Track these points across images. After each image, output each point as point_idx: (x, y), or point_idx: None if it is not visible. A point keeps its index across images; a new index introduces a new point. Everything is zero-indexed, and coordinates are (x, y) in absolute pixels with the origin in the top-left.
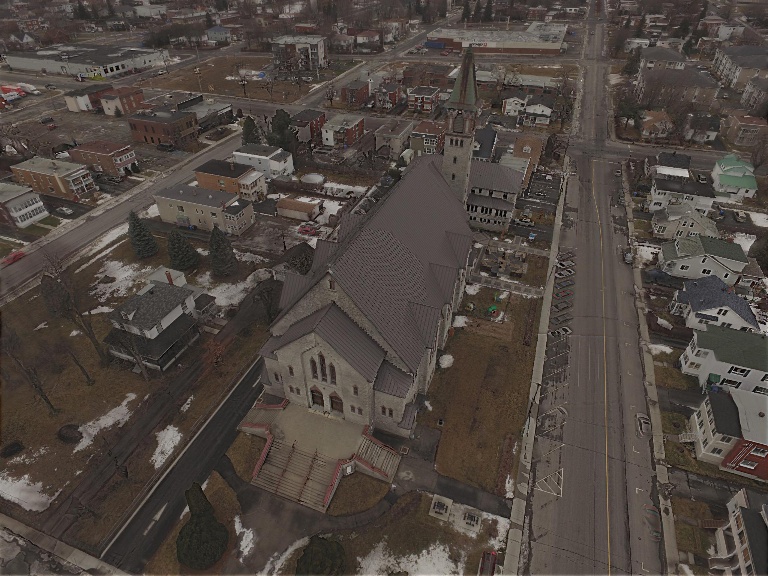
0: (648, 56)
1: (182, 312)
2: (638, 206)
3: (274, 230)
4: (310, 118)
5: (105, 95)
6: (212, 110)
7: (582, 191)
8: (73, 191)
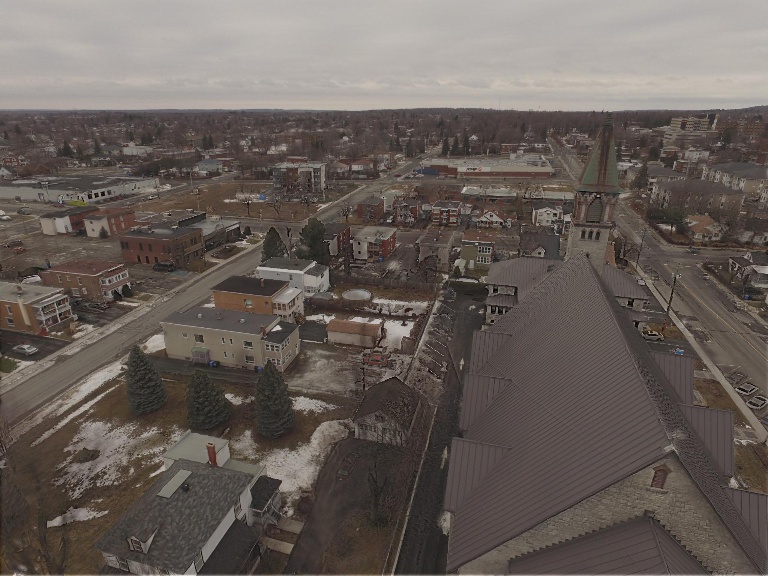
0: (649, 172)
1: (233, 518)
2: (762, 310)
3: (329, 362)
4: (337, 231)
5: (90, 215)
6: (221, 226)
7: (682, 297)
8: (41, 322)
